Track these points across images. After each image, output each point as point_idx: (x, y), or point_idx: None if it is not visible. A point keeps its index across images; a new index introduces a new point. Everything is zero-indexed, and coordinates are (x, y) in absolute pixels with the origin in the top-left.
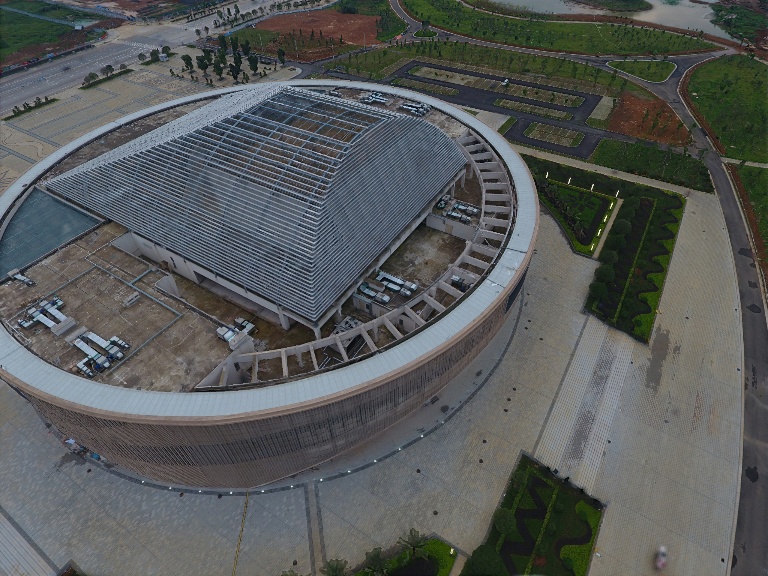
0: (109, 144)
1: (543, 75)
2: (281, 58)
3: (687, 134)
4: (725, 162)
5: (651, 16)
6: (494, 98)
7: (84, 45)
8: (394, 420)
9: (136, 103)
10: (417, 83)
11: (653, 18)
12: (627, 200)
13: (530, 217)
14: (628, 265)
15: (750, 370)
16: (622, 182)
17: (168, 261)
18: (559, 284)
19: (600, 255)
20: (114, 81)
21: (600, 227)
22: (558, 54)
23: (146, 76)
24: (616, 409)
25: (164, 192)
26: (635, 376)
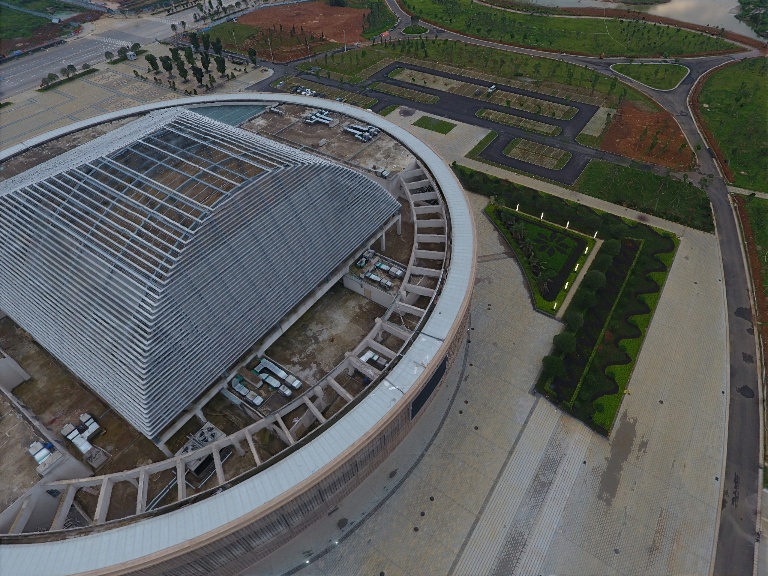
0: (7, 172)
1: (536, 80)
2: (252, 58)
3: (691, 156)
4: (732, 192)
5: (668, 10)
6: (477, 107)
7: (55, 41)
8: (255, 560)
9: (91, 108)
10: (395, 88)
11: (670, 12)
12: (605, 244)
13: (460, 287)
14: (598, 327)
15: (731, 480)
16: (605, 217)
17: (25, 330)
18: (510, 352)
19: (565, 314)
20: (75, 82)
21: (570, 277)
22: (557, 55)
23: (109, 77)
24: (556, 529)
25: (7, 254)
26: (586, 482)
